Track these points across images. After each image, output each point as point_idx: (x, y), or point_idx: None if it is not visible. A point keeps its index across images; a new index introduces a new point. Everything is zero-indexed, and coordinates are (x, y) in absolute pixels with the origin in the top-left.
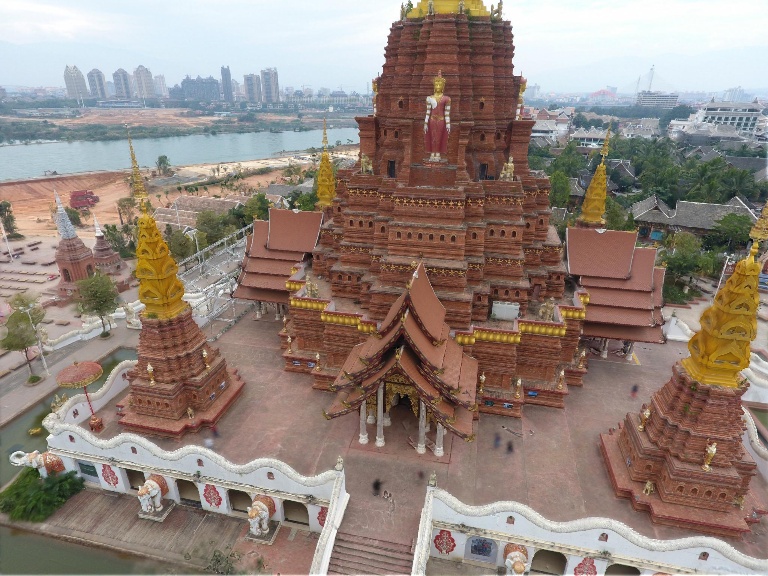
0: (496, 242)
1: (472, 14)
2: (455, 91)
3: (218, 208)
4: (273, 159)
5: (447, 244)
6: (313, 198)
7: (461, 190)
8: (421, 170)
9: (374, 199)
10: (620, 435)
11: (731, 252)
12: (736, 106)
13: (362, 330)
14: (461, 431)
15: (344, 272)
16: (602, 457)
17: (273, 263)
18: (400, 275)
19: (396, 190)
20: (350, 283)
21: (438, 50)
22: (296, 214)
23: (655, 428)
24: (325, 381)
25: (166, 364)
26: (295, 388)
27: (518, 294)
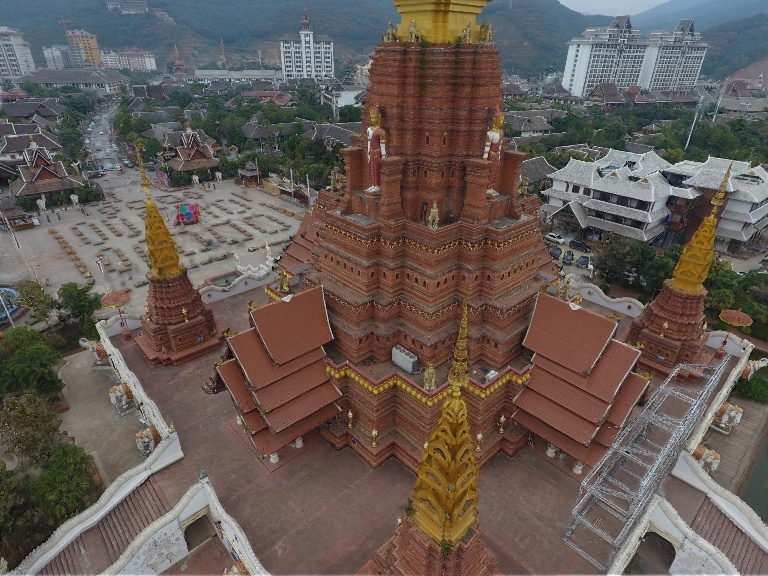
0: None
1: None
2: None
3: None
4: None
5: None
6: None
7: None
8: None
9: None
10: None
11: None
12: None
13: None
14: None
15: None
16: None
17: None
18: None
19: None
20: None
21: None
22: None
23: None
24: None
25: None
26: None
27: None
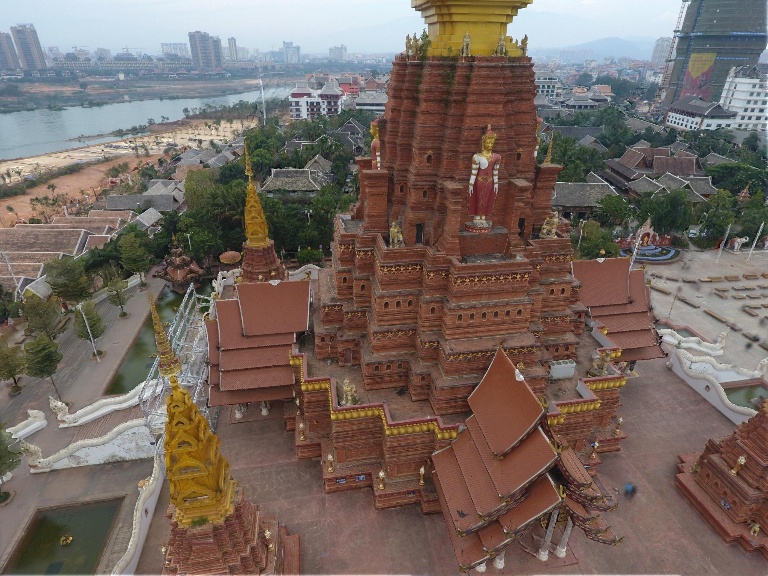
0: (545, 301)
1: (508, 54)
2: (502, 146)
3: (53, 241)
4: (76, 150)
5: (513, 319)
6: (196, 219)
7: (528, 261)
8: (469, 238)
9: (413, 275)
10: (698, 475)
11: (611, 228)
12: (539, 75)
13: (443, 438)
14: (607, 537)
15: (383, 362)
16: (686, 498)
17: (256, 352)
18: (468, 363)
19: (457, 269)
20: (389, 372)
21: (483, 100)
22: (275, 286)
23: (752, 473)
24: (391, 497)
25: (228, 575)
26: (356, 516)
27: (567, 349)
